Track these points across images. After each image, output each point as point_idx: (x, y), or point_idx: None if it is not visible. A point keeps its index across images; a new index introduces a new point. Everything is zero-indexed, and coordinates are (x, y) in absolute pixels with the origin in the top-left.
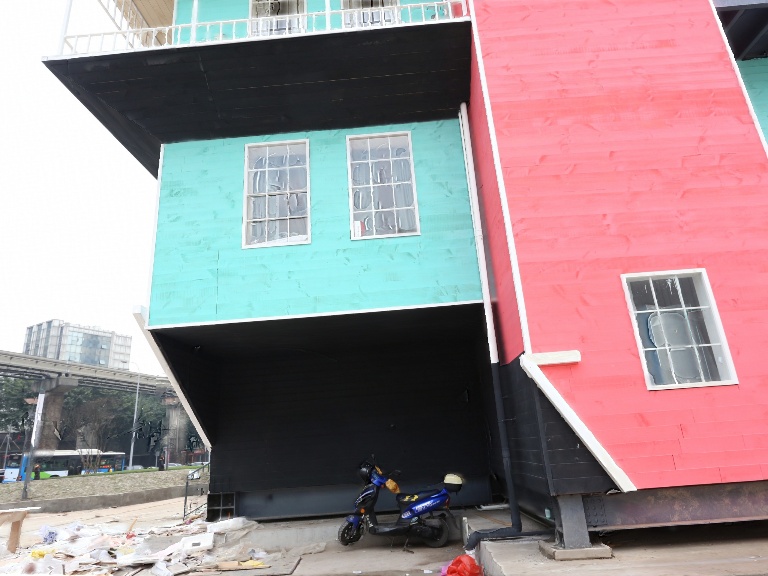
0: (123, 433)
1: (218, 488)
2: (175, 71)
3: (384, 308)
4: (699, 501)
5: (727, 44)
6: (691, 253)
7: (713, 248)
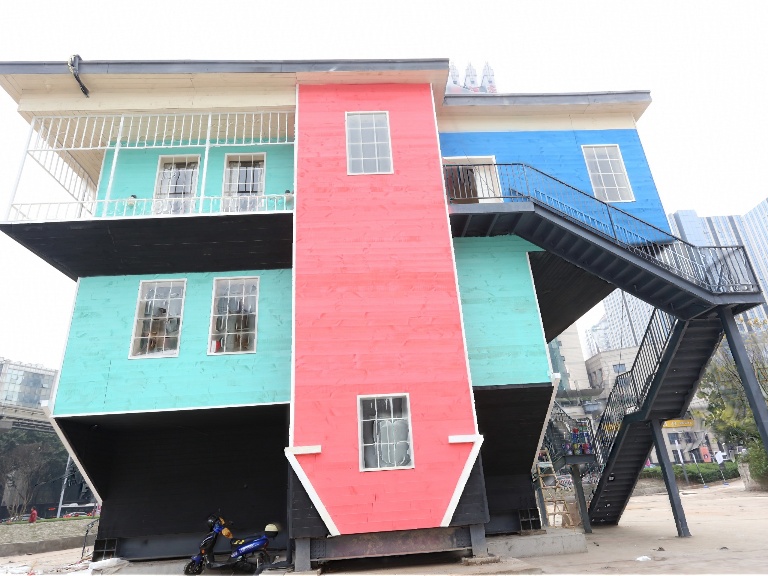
0: (52, 480)
1: (104, 535)
2: (90, 233)
3: (223, 406)
4: (383, 542)
5: (451, 242)
6: (402, 383)
7: (416, 380)
